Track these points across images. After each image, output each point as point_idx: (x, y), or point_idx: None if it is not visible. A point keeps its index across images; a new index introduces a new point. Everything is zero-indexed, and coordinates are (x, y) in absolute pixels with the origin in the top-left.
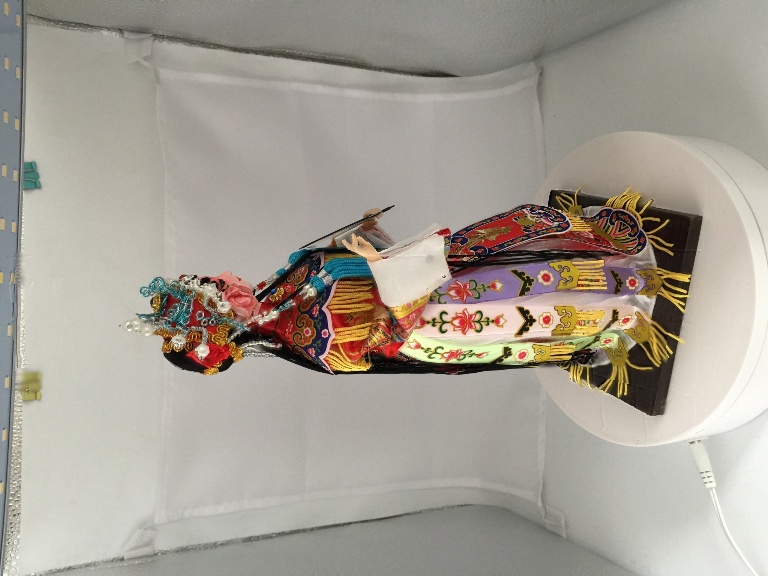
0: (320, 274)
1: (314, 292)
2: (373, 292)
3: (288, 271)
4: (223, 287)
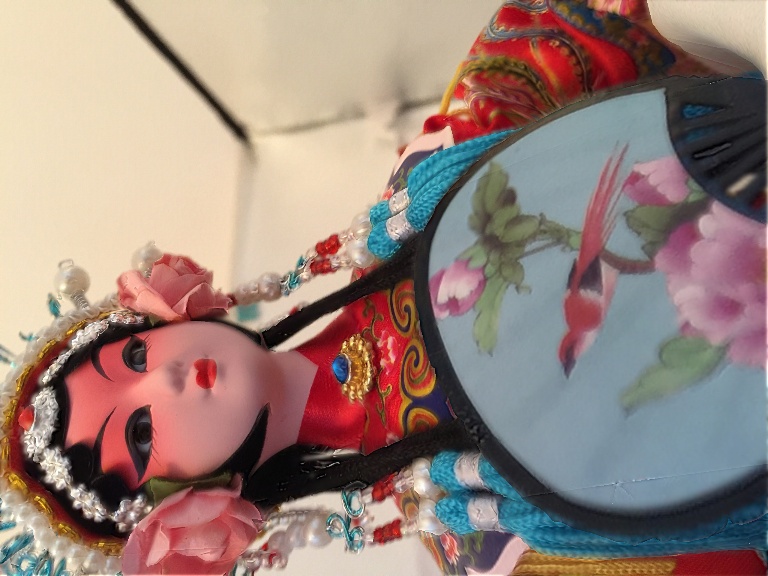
0: (468, 468)
1: (437, 533)
2: (681, 570)
3: (398, 259)
4: (145, 469)
